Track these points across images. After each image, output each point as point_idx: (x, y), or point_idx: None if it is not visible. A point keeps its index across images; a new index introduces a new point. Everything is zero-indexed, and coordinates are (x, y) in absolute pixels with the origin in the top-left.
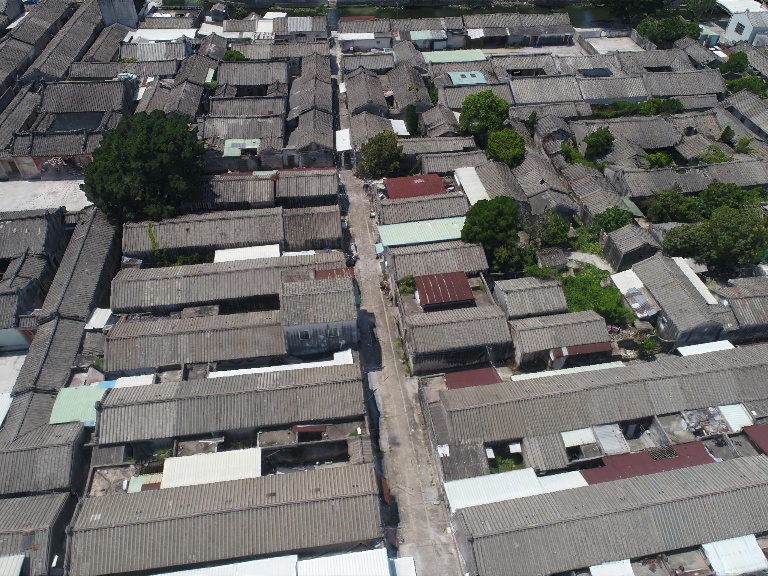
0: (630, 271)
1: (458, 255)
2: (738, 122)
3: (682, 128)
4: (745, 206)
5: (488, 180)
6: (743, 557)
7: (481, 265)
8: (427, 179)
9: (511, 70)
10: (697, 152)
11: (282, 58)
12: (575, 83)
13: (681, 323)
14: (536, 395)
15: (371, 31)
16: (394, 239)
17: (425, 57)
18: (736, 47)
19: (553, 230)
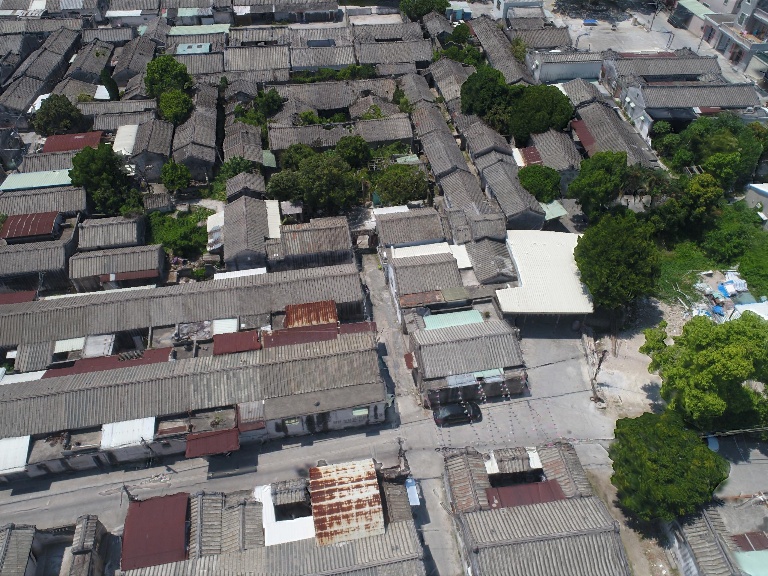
0: (223, 212)
1: (60, 197)
2: (423, 86)
3: (359, 91)
4: (375, 158)
5: (141, 135)
6: (133, 434)
7: (79, 206)
8: (88, 135)
9: (247, 42)
10: (360, 111)
11: (36, 33)
12: (287, 52)
13: (228, 253)
14: (42, 309)
15: (140, 8)
16: (13, 185)
17: (171, 31)
18: (473, 20)
19: (169, 177)
